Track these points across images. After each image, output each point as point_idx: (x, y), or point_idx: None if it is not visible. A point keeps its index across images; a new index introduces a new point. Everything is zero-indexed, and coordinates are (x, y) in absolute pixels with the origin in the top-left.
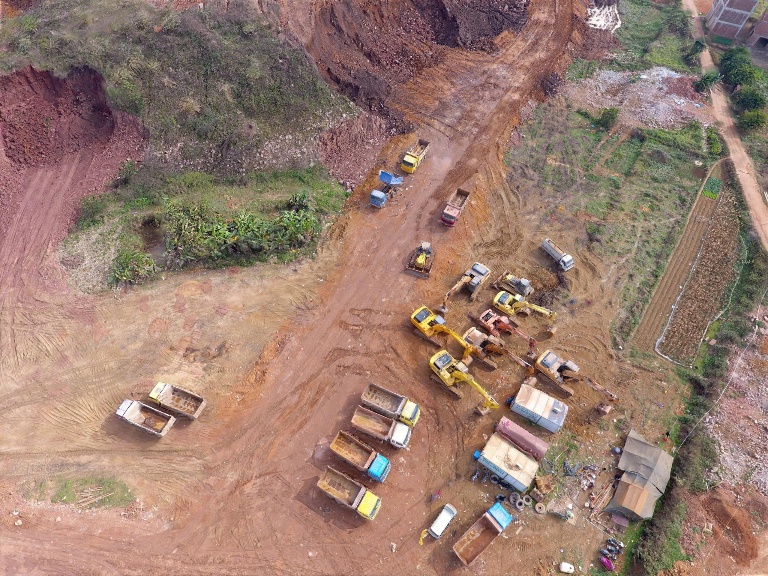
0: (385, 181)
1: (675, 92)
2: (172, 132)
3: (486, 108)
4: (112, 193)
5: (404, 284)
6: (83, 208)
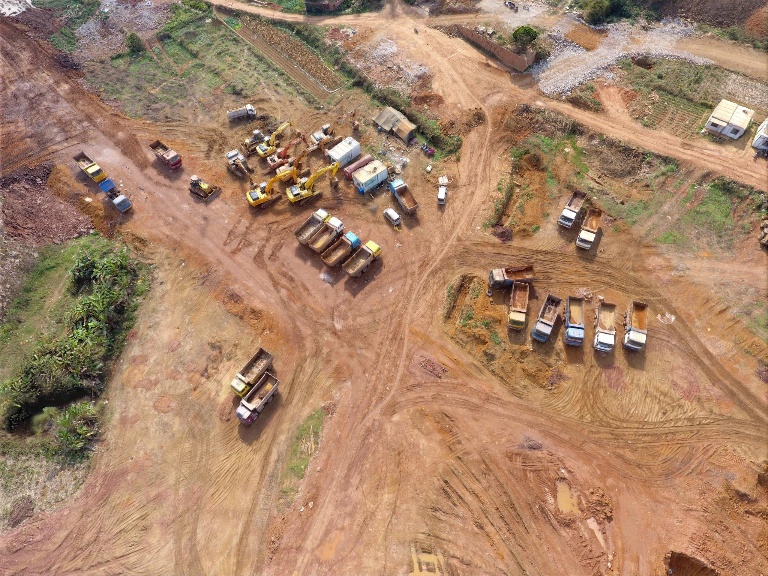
0: (110, 188)
1: (137, 1)
2: None
3: (64, 109)
4: None
5: (219, 206)
6: None
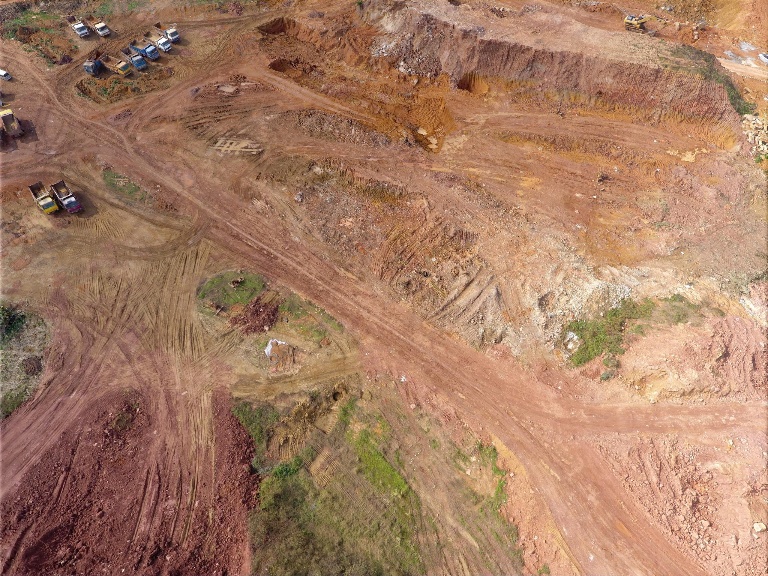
0: None
1: None
2: None
3: None
4: None
5: None
6: None
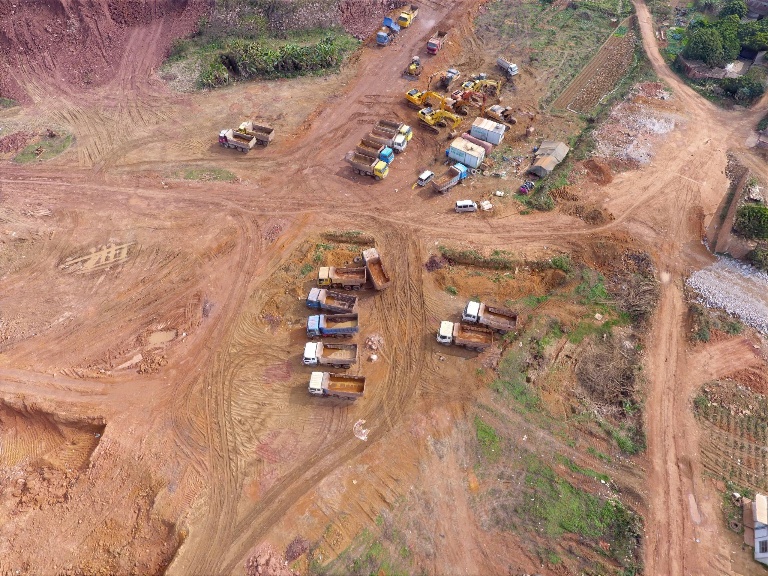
0: (387, 25)
1: None
2: (231, 1)
3: None
4: (191, 41)
5: (401, 83)
6: (172, 49)
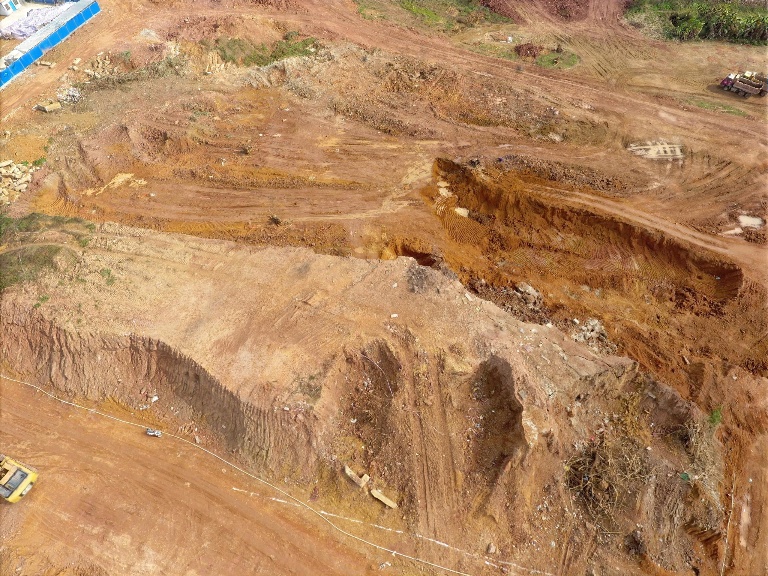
0: None
1: None
2: None
3: None
4: None
5: None
6: (631, 2)
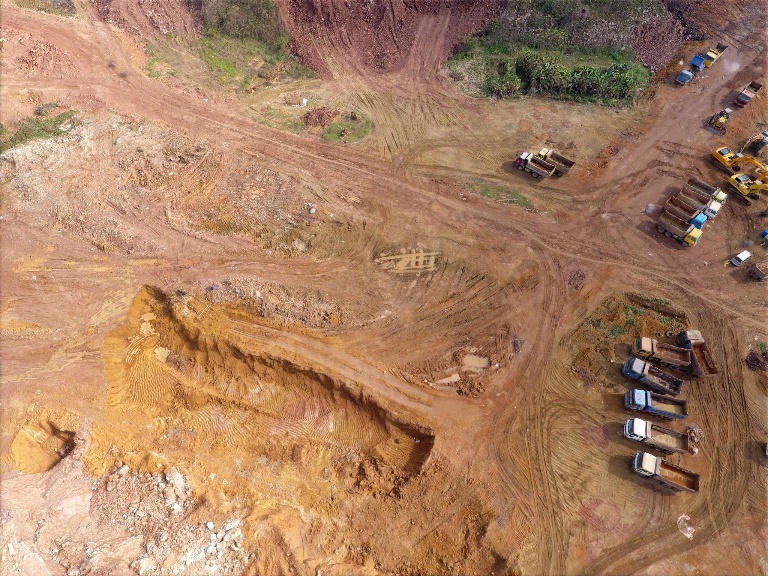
0: (696, 64)
1: None
2: (525, 4)
3: None
4: (477, 40)
5: (704, 135)
6: (459, 45)
